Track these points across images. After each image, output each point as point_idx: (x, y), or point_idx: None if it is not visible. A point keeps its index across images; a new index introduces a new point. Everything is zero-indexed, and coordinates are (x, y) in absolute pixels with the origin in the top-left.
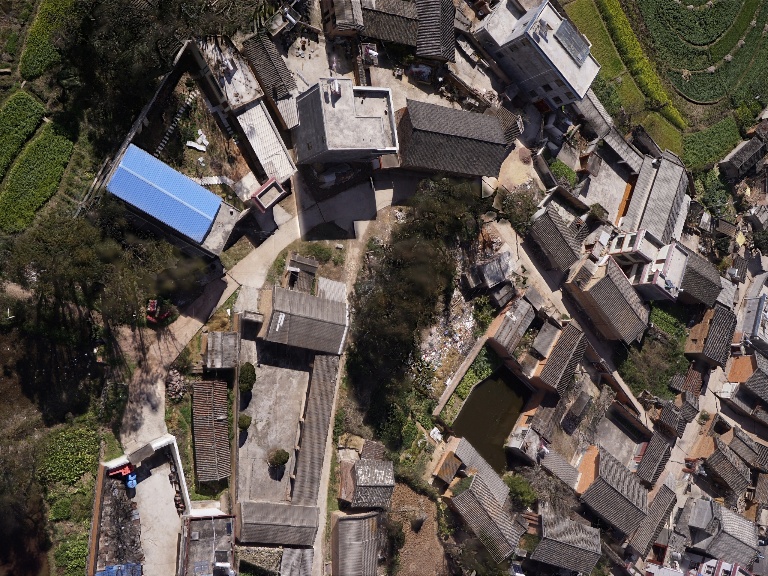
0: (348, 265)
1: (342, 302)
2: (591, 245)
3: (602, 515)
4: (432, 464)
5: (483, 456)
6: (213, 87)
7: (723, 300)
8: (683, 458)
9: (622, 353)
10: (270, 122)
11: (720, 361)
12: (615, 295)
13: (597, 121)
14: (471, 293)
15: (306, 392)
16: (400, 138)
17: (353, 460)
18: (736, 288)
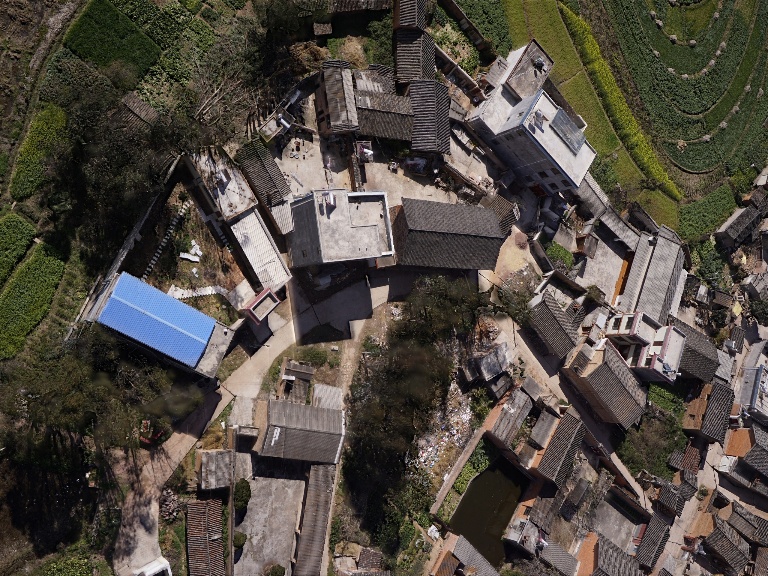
0: (344, 366)
1: (338, 408)
2: (588, 327)
3: None
4: (430, 563)
5: (481, 548)
6: (206, 196)
7: (720, 373)
8: (682, 535)
9: (620, 434)
10: (264, 230)
11: (718, 438)
12: (613, 381)
13: (593, 201)
14: (468, 385)
15: (302, 502)
16: (396, 236)
17: (350, 569)
18: (733, 360)
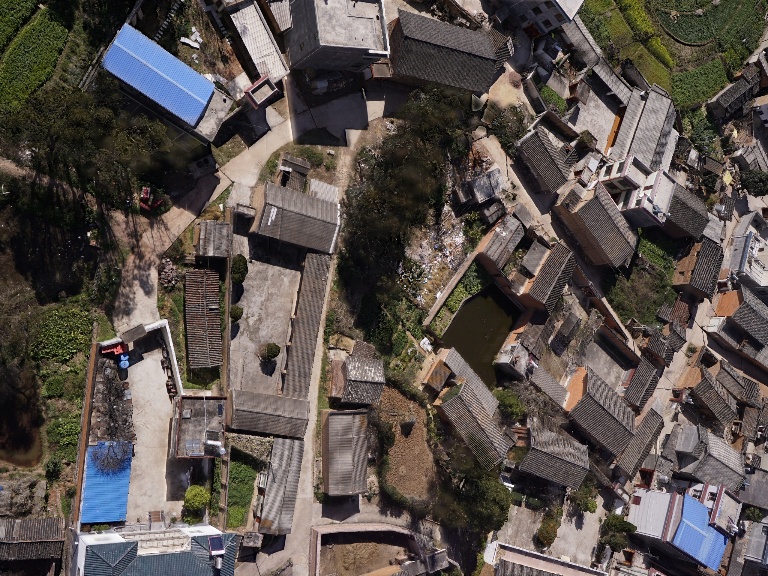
0: (340, 172)
1: (333, 204)
2: (580, 171)
3: (590, 433)
4: (422, 373)
5: None
6: None
7: (710, 235)
8: (670, 388)
9: (610, 280)
10: (263, 23)
11: (707, 291)
12: (603, 217)
13: (586, 50)
14: (461, 209)
15: (297, 291)
16: (392, 49)
17: None
18: (723, 224)
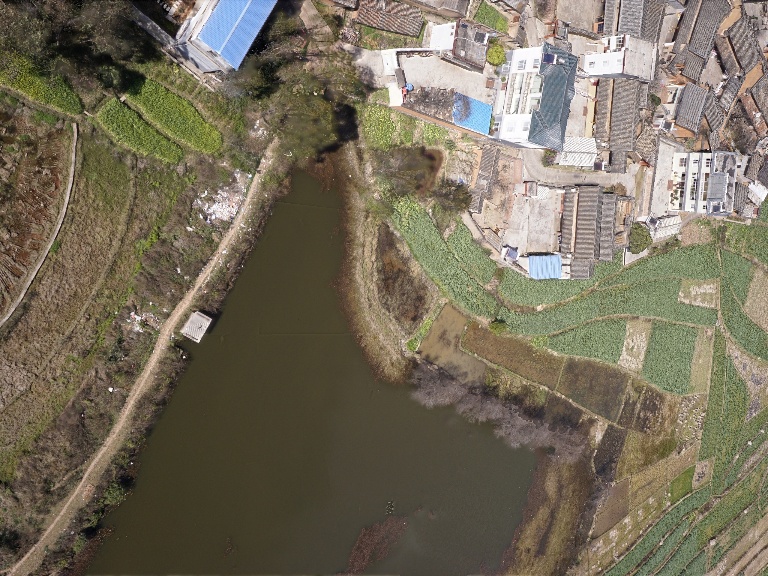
0: None
1: None
2: None
3: None
4: None
5: None
6: None
7: None
8: None
9: None
10: None
11: None
12: None
13: None
14: None
15: None
16: None
17: None
18: None
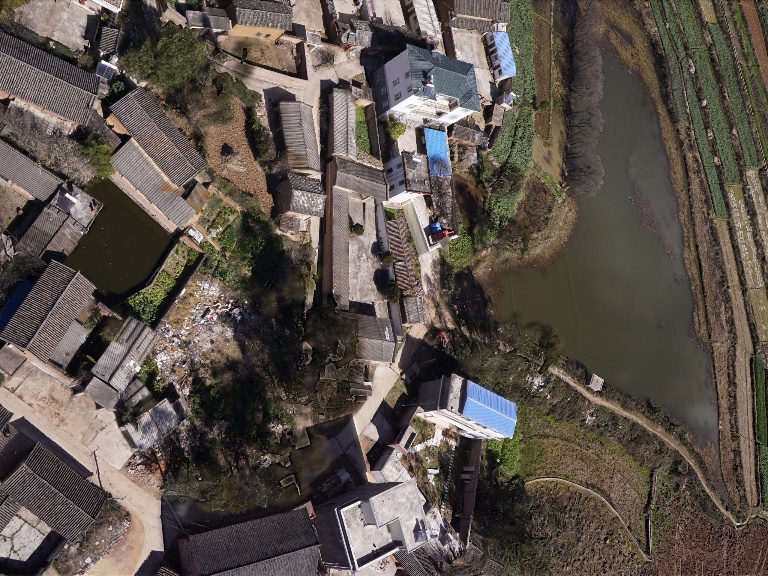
0: None
1: None
2: None
3: None
4: None
5: None
6: None
7: None
8: None
9: None
10: None
11: None
12: None
13: None
14: (163, 395)
15: None
16: None
17: None
18: None
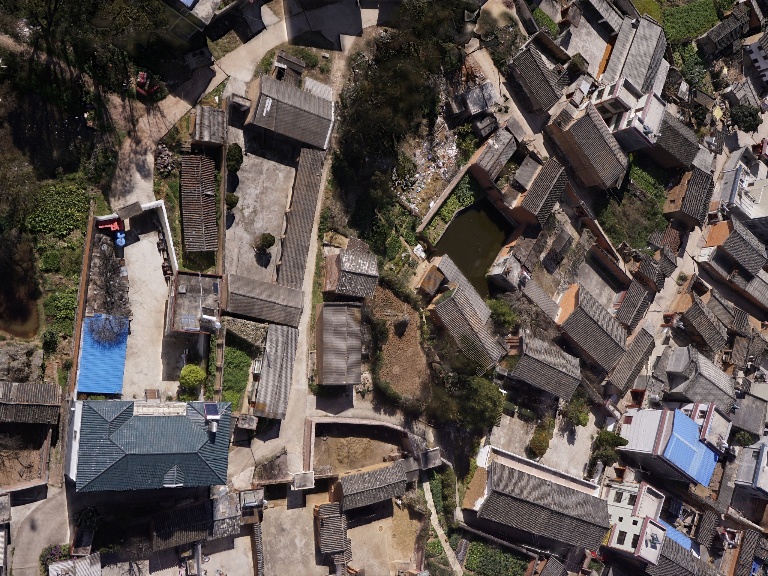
0: (334, 75)
1: None
2: (572, 93)
3: (582, 347)
4: (415, 279)
5: None
6: None
7: (701, 166)
8: (661, 314)
9: (602, 202)
10: None
11: (697, 217)
12: (595, 135)
13: None
14: (454, 122)
15: (292, 186)
16: None
17: None
18: (713, 156)
